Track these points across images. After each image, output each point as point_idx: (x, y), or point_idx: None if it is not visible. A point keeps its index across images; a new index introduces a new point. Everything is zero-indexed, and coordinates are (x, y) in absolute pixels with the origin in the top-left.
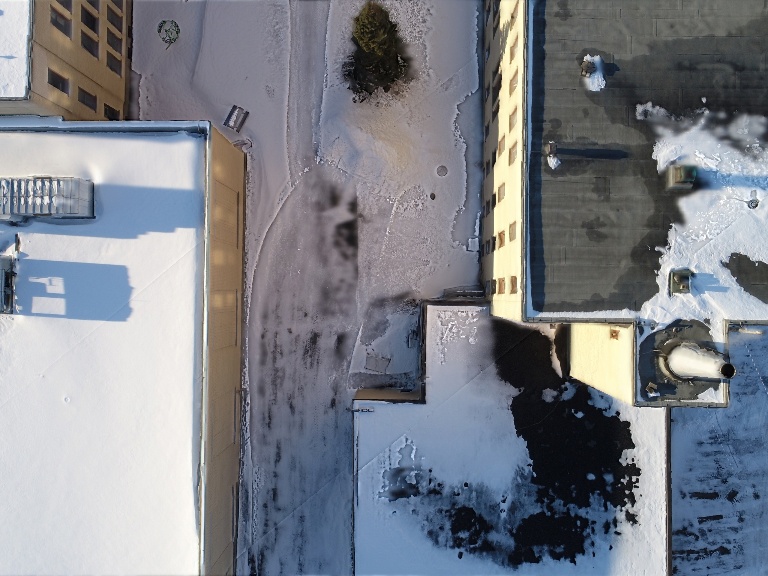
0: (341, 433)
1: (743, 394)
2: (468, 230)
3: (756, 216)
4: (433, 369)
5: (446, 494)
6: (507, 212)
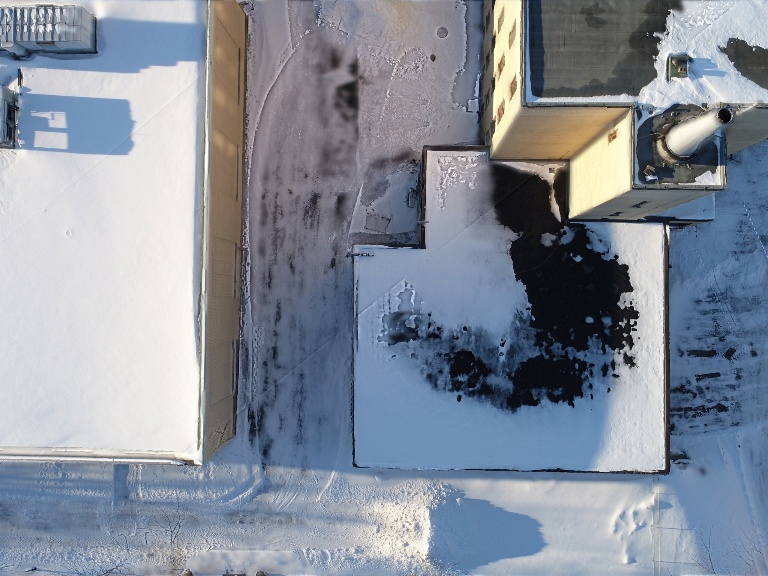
0: (341, 293)
1: (741, 253)
2: (468, 91)
3: (753, 1)
4: (433, 214)
5: (445, 338)
6: (507, 26)
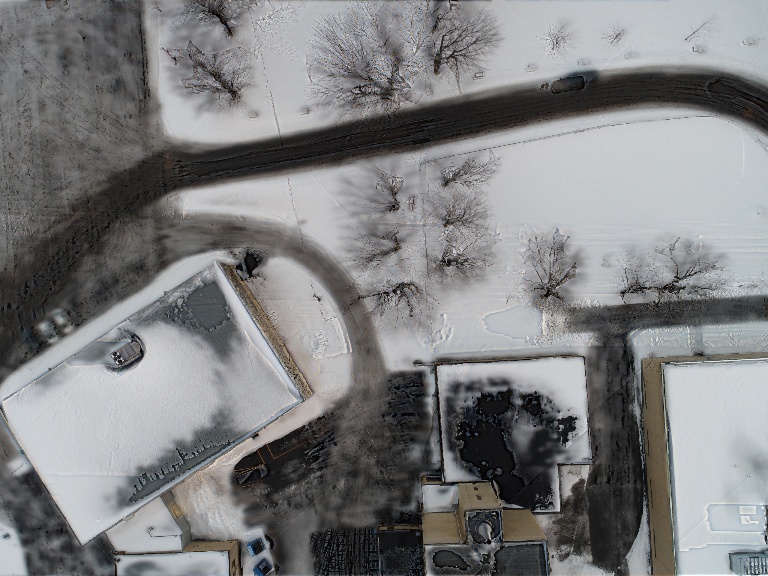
0: (592, 434)
1: (393, 465)
2: None
3: None
4: (556, 481)
5: (545, 421)
6: None
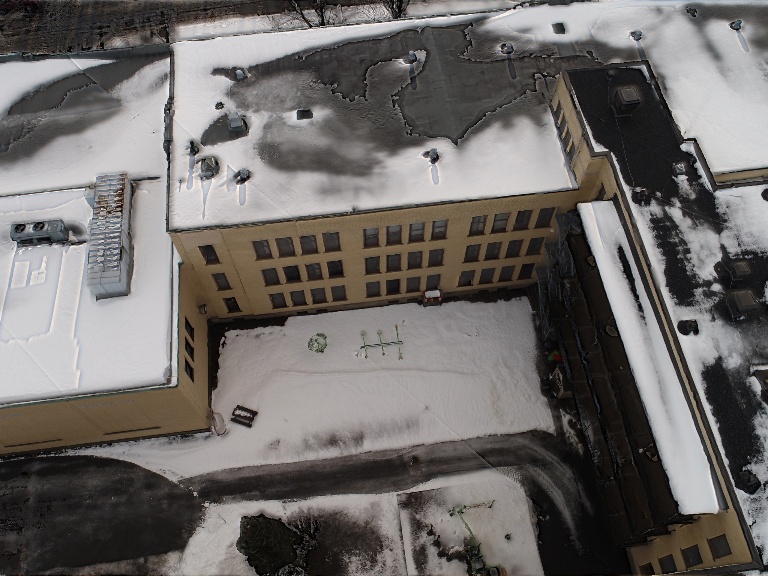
0: None
1: None
2: None
3: None
4: None
5: None
6: None
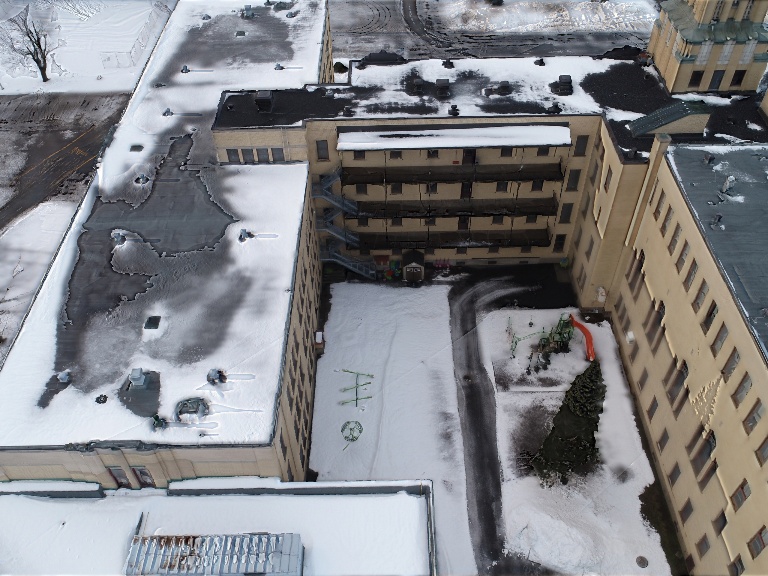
0: None
1: None
2: None
3: None
4: None
5: None
6: None
